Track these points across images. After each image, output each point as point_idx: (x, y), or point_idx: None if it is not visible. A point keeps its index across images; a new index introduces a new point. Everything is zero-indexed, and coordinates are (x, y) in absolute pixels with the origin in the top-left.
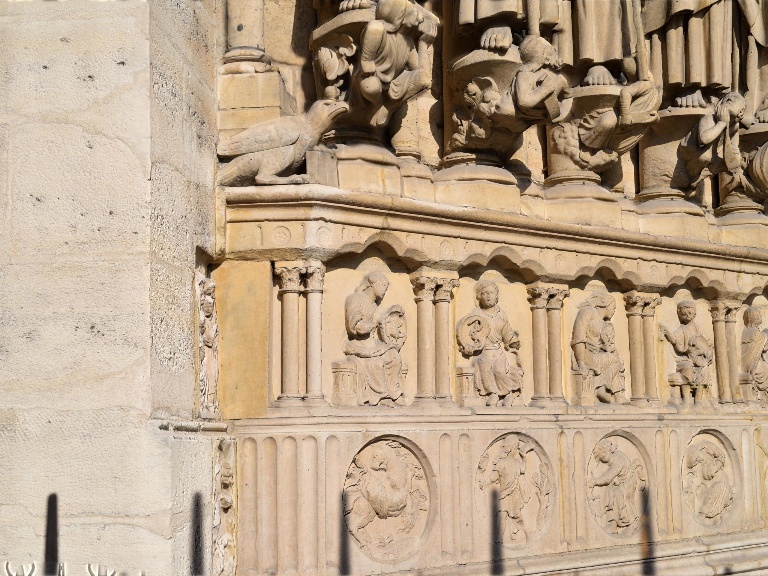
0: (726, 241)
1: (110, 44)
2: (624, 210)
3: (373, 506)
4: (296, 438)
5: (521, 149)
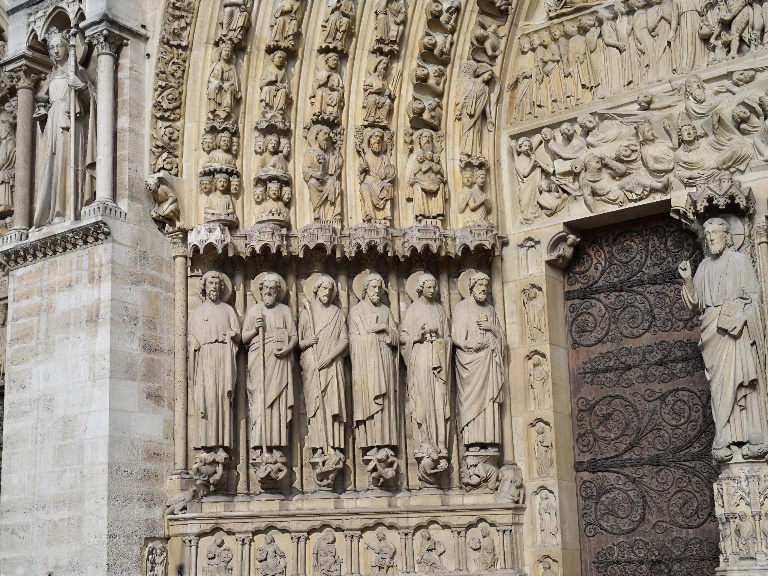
0: (412, 503)
1: None
2: (348, 498)
3: None
4: None
5: (296, 482)
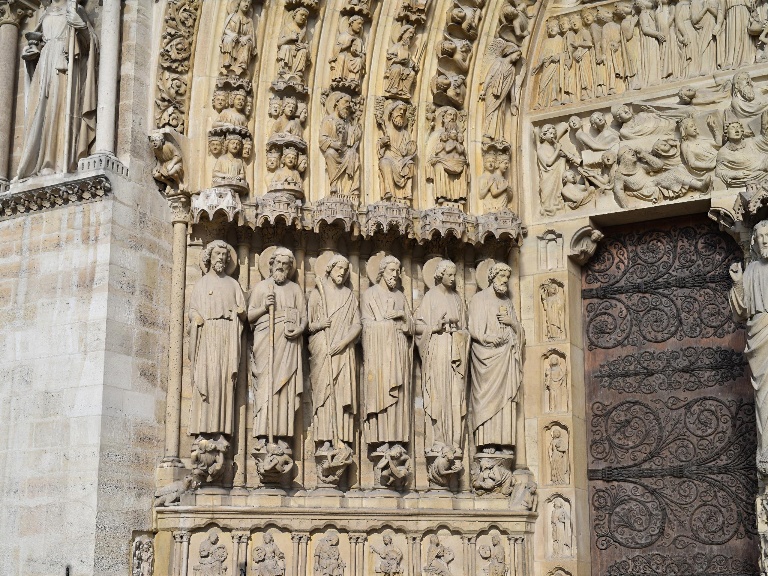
0: (421, 505)
1: (90, 479)
2: (353, 497)
3: None
4: None
5: (297, 477)
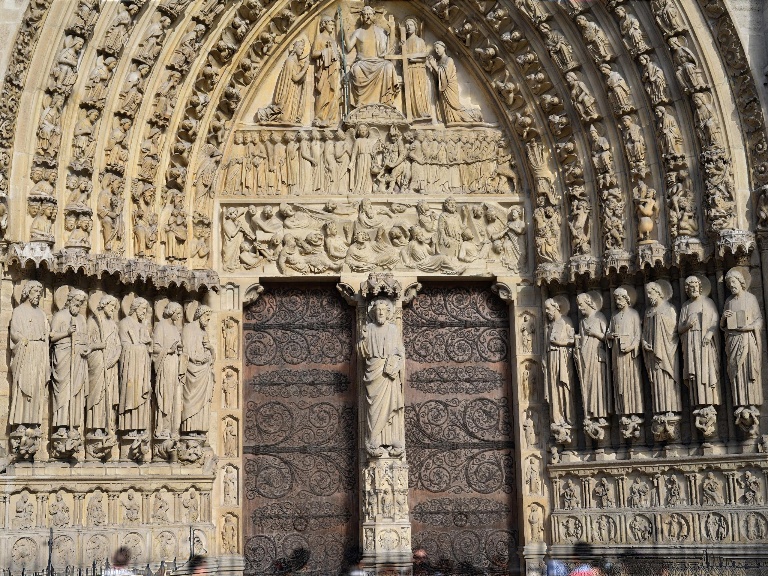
0: (150, 472)
1: None
2: (110, 467)
3: (21, 555)
4: (1, 538)
5: (75, 453)
